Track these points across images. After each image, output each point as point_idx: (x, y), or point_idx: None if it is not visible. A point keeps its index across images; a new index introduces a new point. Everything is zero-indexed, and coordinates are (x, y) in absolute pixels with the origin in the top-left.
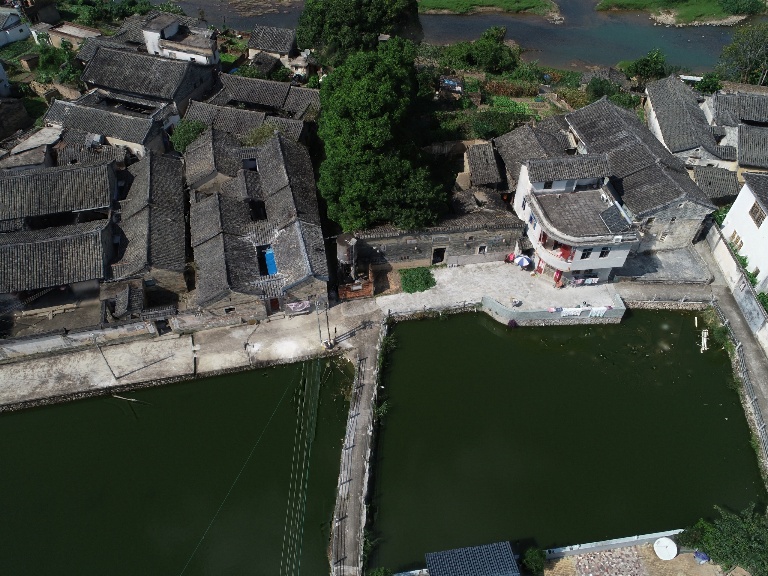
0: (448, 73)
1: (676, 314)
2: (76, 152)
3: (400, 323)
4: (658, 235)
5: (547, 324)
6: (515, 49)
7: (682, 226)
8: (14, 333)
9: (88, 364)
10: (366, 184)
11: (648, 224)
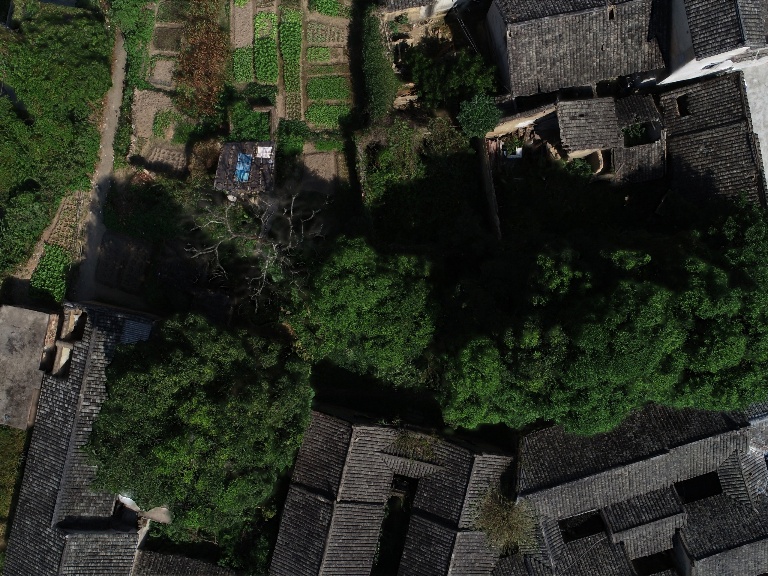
0: None
1: None
2: None
3: None
4: None
5: None
6: (20, 7)
7: None
8: None
9: None
10: None
11: None
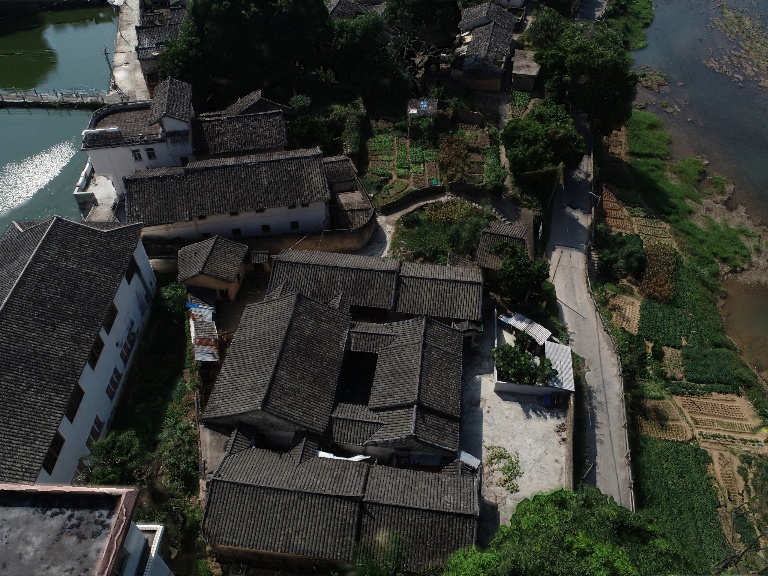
0: (477, 120)
1: None
2: None
3: None
4: None
5: None
6: None
7: None
8: (152, 3)
9: None
10: None
11: None
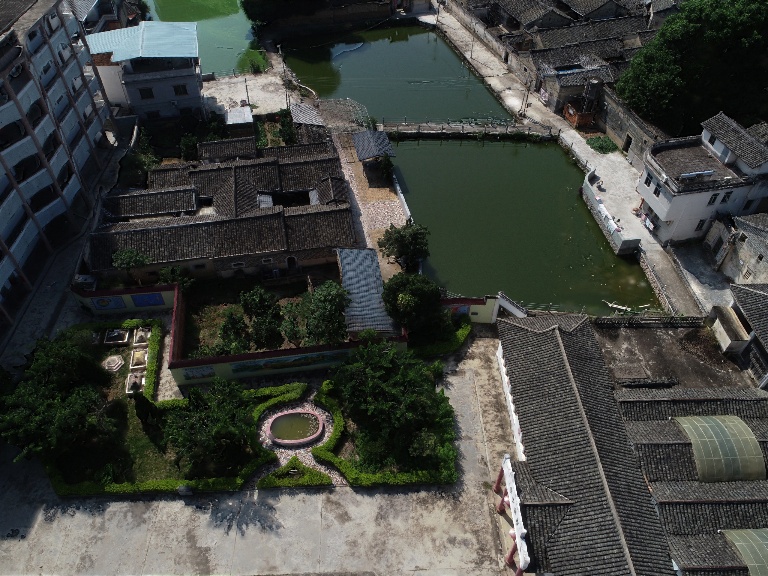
0: None
1: (649, 294)
2: (632, 3)
3: (559, 146)
4: (744, 266)
5: (592, 211)
6: None
7: (766, 276)
8: None
9: (477, 49)
10: (642, 61)
11: (741, 242)
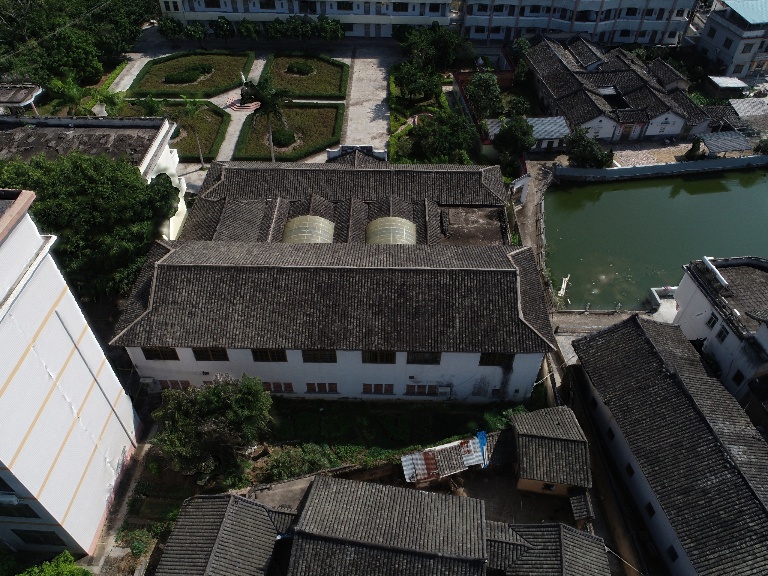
0: None
1: None
2: None
3: None
4: None
5: None
6: None
7: None
8: None
9: None
10: None
11: None
